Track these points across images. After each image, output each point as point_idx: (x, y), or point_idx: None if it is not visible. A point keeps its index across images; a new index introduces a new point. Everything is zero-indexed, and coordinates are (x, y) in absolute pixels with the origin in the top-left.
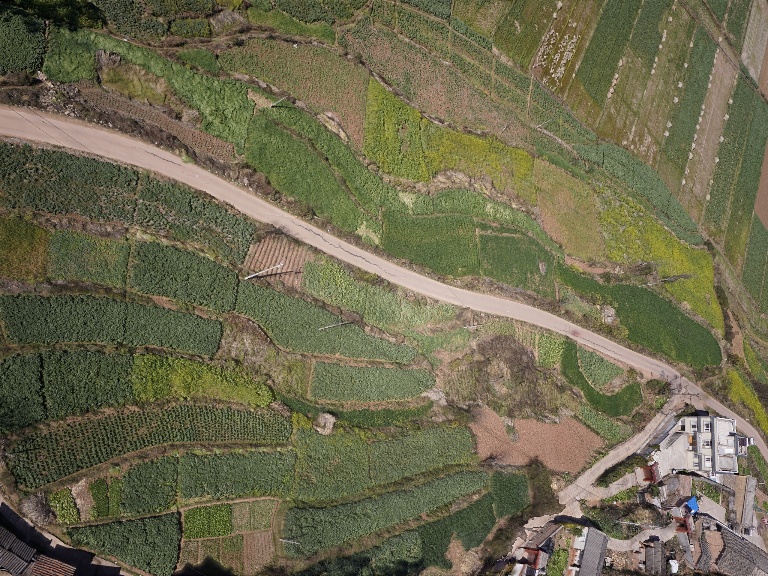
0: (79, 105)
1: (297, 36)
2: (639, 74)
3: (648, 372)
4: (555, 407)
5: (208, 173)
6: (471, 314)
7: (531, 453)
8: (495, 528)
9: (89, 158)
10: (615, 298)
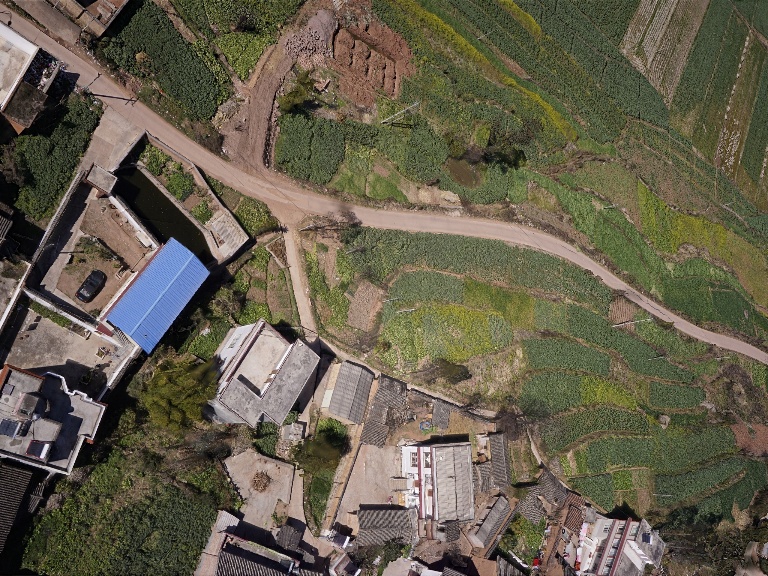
0: None
1: (601, 155)
2: None
3: None
4: None
5: (588, 258)
6: (718, 349)
7: (763, 448)
8: (753, 497)
9: (541, 252)
10: None
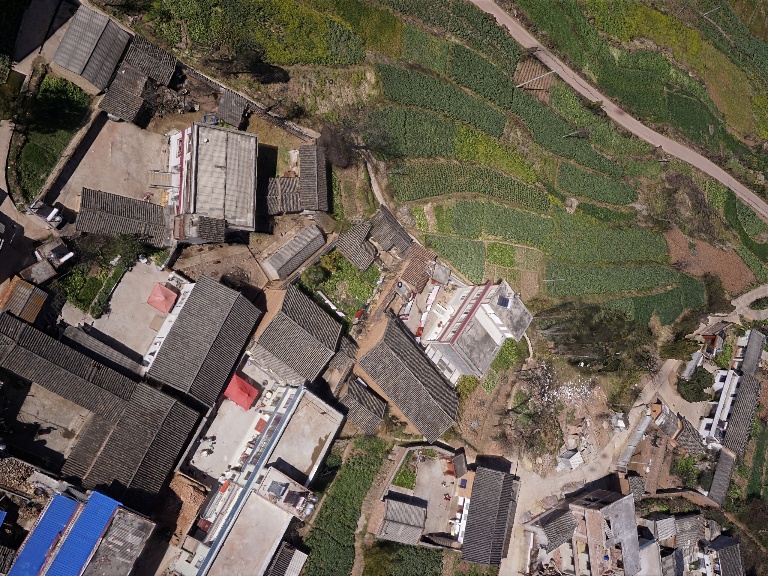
0: None
1: None
2: None
3: None
4: (722, 239)
5: (492, 2)
6: (663, 151)
7: (705, 269)
8: (681, 315)
9: None
10: (764, 168)
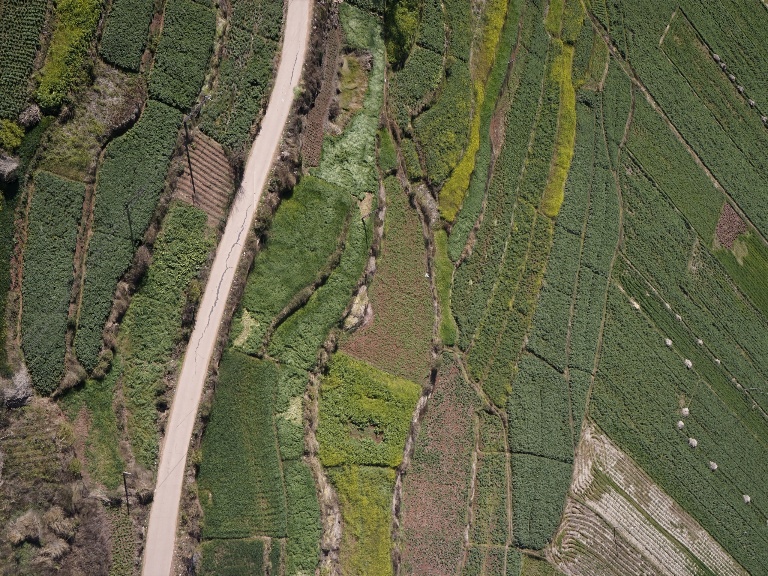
0: None
1: None
2: None
3: None
4: None
5: (288, 112)
6: (146, 489)
7: None
8: None
9: (284, 0)
10: None
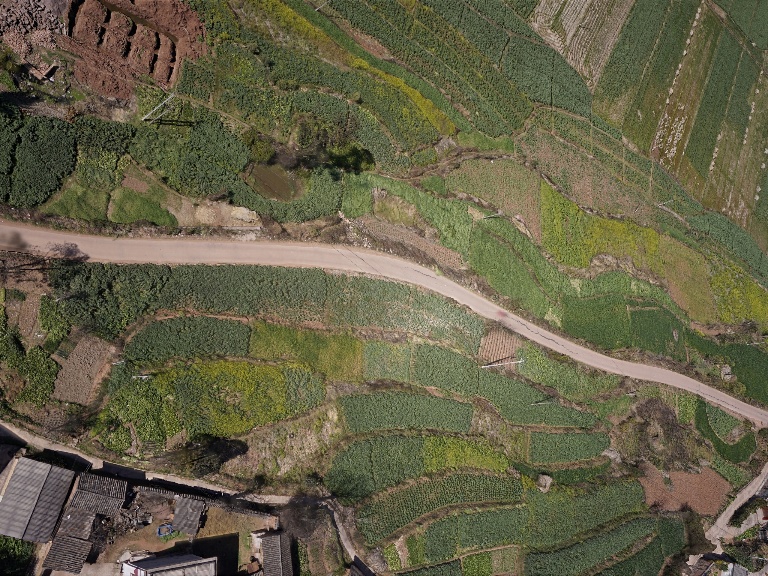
0: (369, 237)
1: (491, 151)
2: (733, 145)
3: (759, 422)
4: (696, 459)
5: (452, 282)
6: (631, 382)
7: (682, 500)
8: (663, 565)
9: (380, 280)
10: (730, 356)
